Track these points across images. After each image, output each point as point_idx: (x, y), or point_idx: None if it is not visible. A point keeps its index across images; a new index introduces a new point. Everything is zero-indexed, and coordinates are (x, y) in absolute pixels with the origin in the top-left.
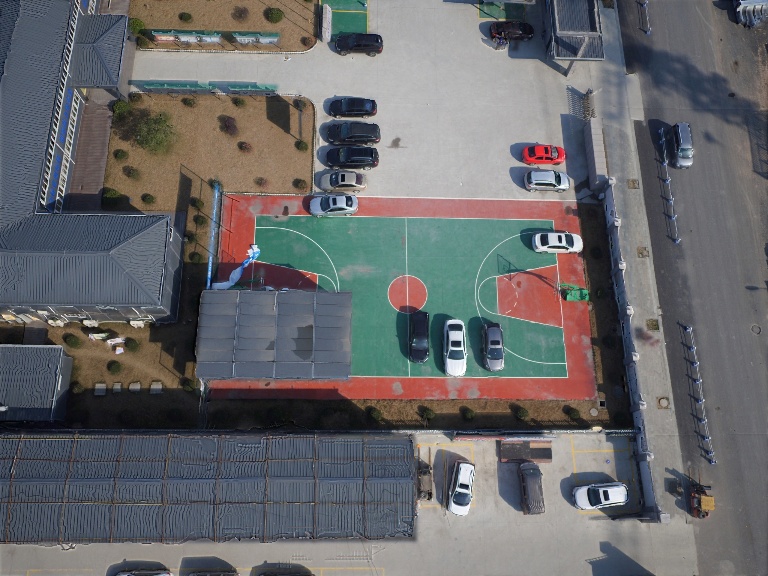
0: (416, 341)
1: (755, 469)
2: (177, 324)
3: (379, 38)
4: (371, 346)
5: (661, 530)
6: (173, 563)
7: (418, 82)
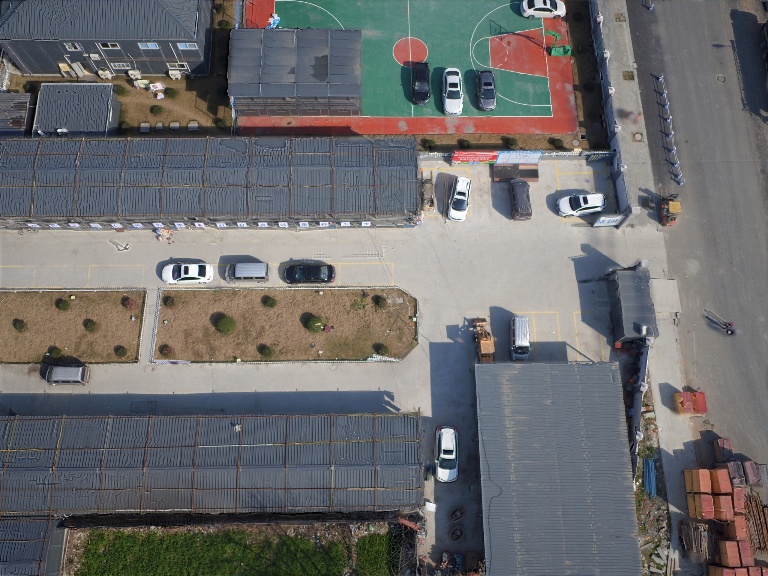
0: (418, 84)
1: (719, 189)
2: (209, 77)
3: None
4: (379, 93)
5: (635, 236)
6: (212, 260)
7: None
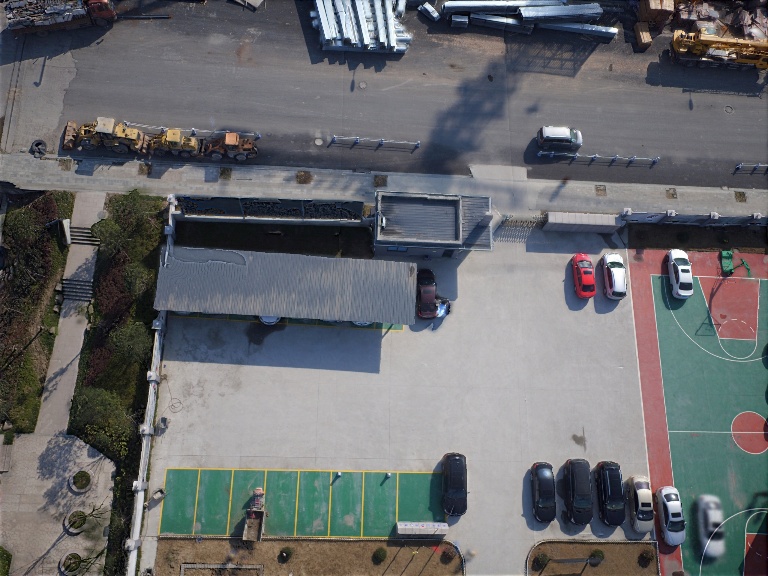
0: None
1: None
2: None
3: (453, 458)
4: None
5: None
6: None
7: (497, 410)
